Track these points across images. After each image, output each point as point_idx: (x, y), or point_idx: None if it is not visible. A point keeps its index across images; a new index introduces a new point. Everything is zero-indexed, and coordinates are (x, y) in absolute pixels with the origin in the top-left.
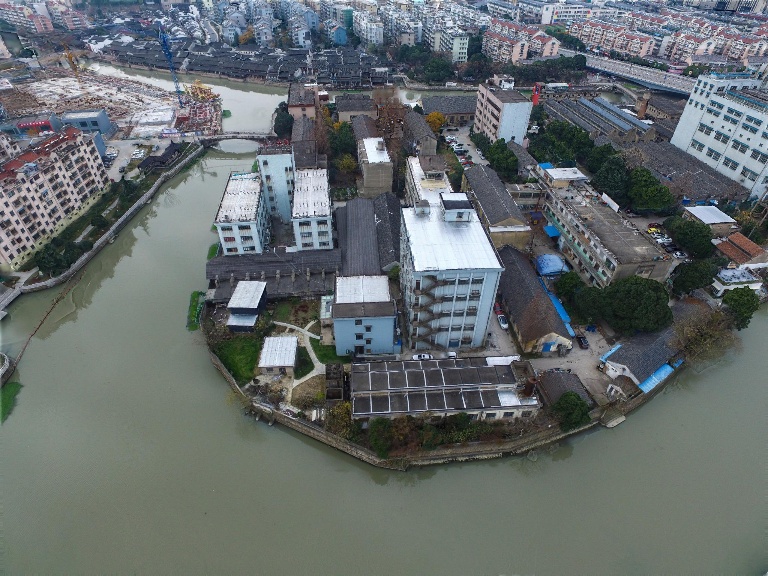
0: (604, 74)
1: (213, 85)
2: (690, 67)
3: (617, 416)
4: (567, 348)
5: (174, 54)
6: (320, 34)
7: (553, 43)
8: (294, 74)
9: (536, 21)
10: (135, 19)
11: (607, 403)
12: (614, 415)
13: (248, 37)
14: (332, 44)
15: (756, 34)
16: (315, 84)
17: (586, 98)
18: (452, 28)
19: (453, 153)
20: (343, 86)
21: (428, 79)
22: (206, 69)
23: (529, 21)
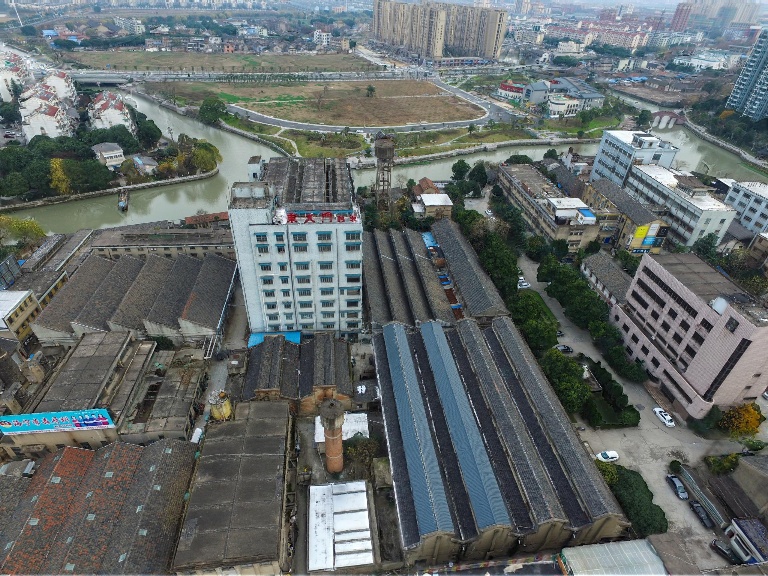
0: None
1: None
2: None
3: None
4: None
5: None
6: None
7: None
8: None
9: None
10: None
11: (533, 163)
12: None
13: None
14: None
15: None
16: None
17: None
18: None
19: None
20: None
21: None
22: None
23: None
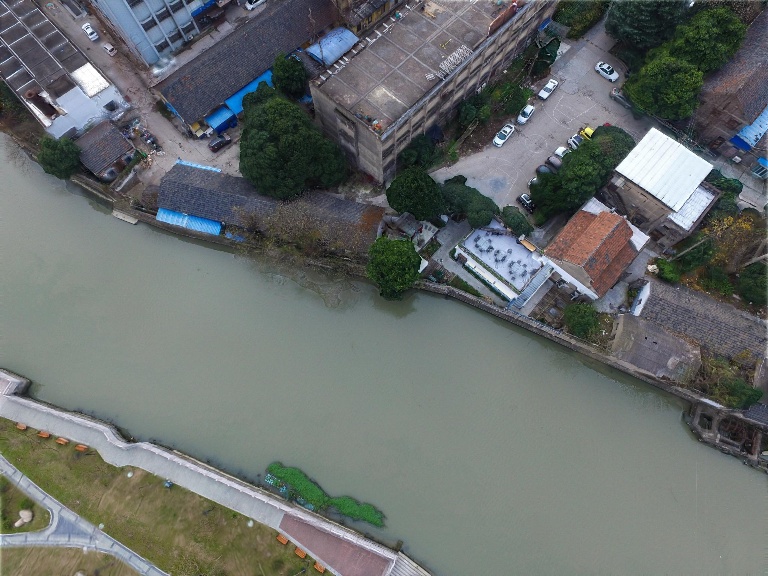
0: None
1: None
2: None
3: (131, 214)
4: (194, 132)
5: None
6: None
7: None
8: None
9: None
10: None
11: (118, 191)
12: (129, 211)
13: None
14: None
15: None
16: None
17: None
18: None
19: None
20: None
21: None
22: None
23: None
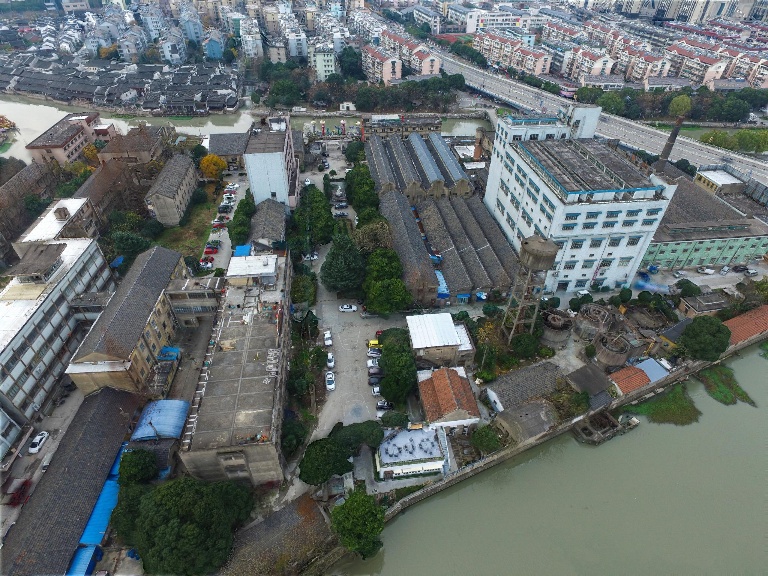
0: (487, 96)
1: (48, 107)
2: (580, 89)
3: None
4: None
5: (9, 71)
6: (200, 46)
7: (432, 60)
8: (120, 97)
9: (460, 30)
10: (20, 27)
11: None
12: None
13: (111, 50)
14: (205, 58)
15: (668, 49)
16: (85, 117)
17: (423, 132)
18: (323, 42)
19: (217, 209)
20: (174, 111)
21: (271, 104)
22: (33, 89)
23: (453, 30)
